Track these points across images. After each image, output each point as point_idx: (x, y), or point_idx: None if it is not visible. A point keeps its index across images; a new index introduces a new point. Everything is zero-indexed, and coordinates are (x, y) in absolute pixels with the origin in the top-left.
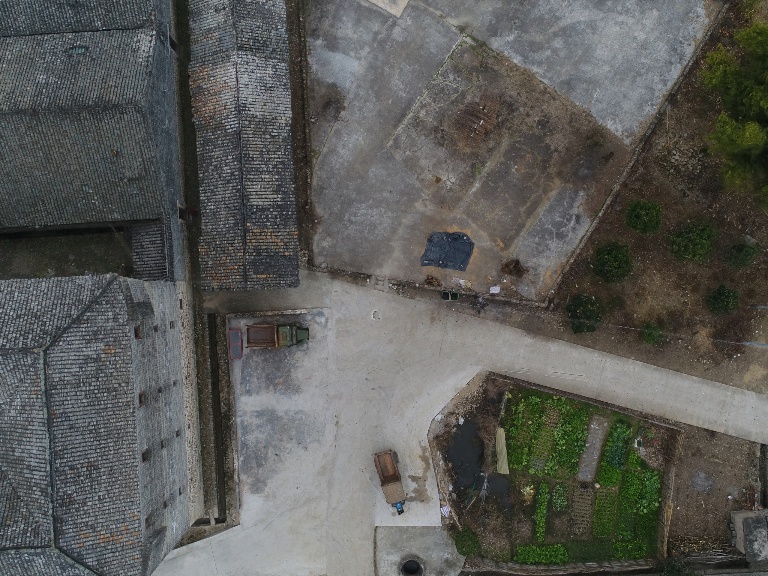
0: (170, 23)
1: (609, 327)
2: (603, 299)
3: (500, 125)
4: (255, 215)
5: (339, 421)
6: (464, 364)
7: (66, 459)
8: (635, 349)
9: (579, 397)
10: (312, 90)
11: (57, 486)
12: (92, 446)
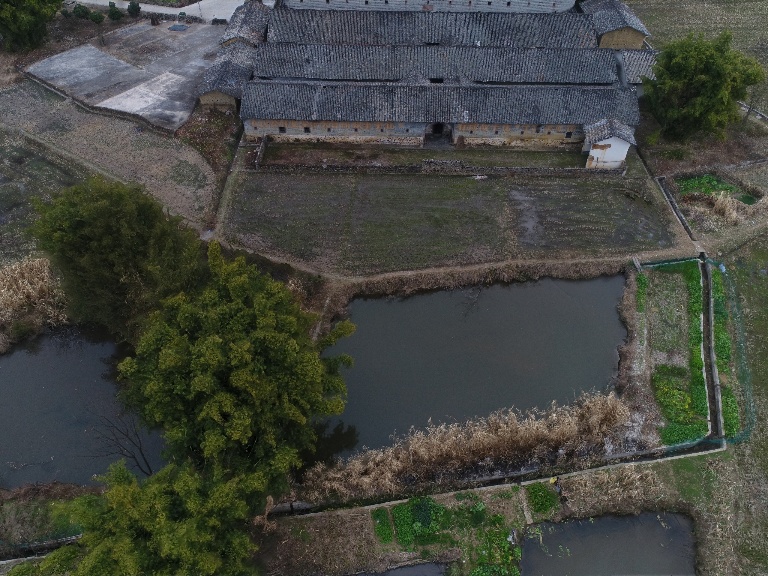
0: None
1: None
2: None
3: None
4: None
5: (238, 0)
6: None
7: None
8: None
9: None
10: None
11: None
12: None
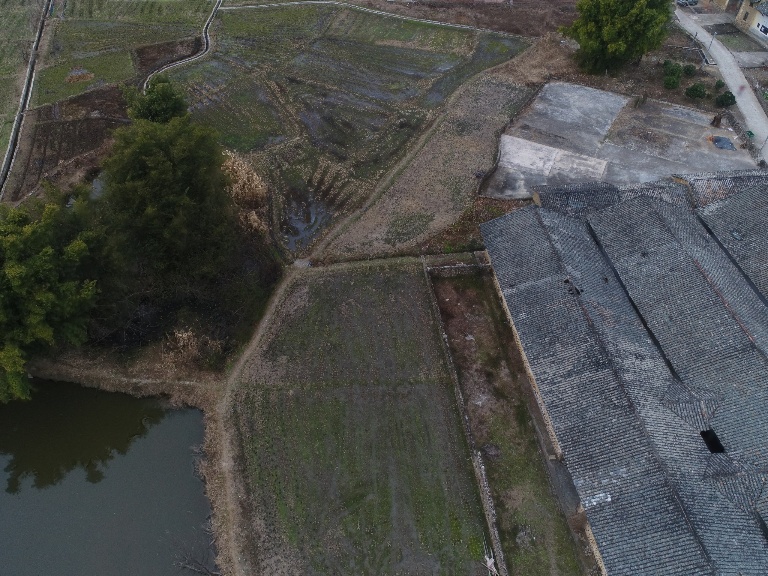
0: None
1: None
2: None
3: None
4: None
5: None
6: None
7: None
8: None
9: (762, 106)
10: None
11: None
12: None
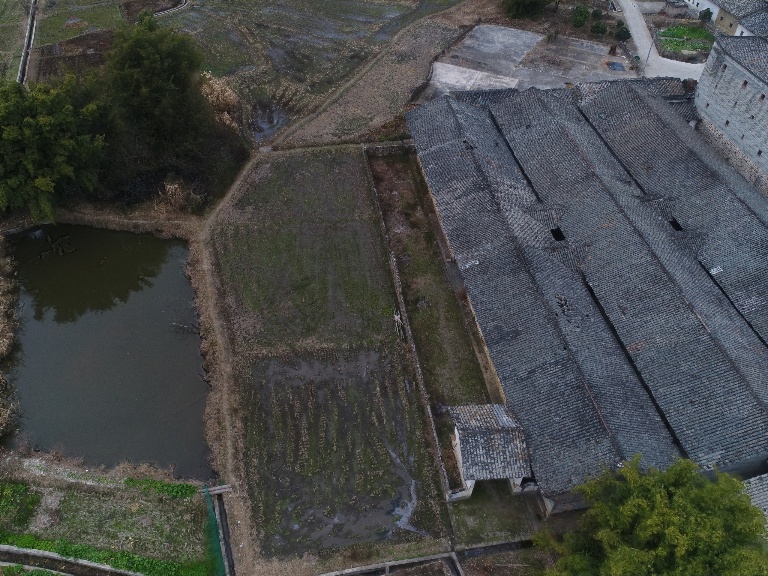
0: None
1: None
2: None
3: None
4: None
5: None
6: (661, 60)
7: None
8: None
9: None
10: None
11: None
12: None
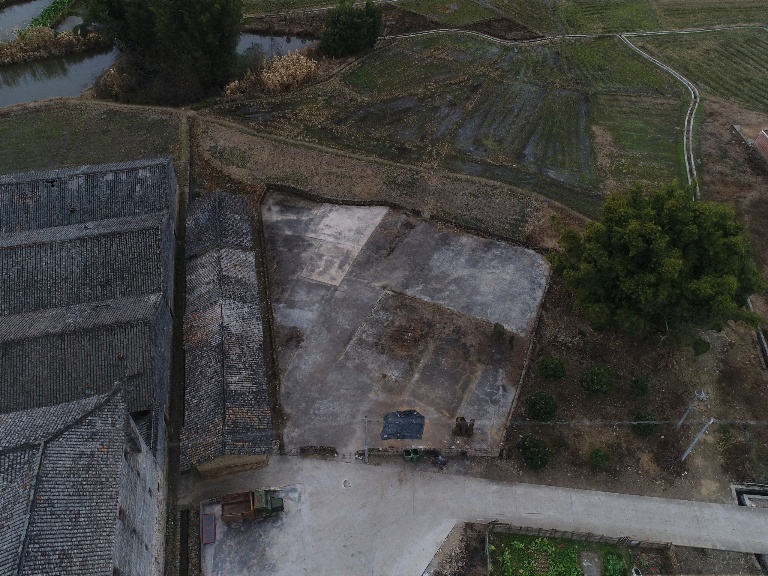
0: (171, 300)
1: (562, 466)
2: (547, 443)
3: (425, 336)
4: (233, 397)
5: None
6: (439, 518)
7: (40, 545)
8: (593, 482)
9: None
10: (278, 332)
11: (23, 572)
12: (69, 534)
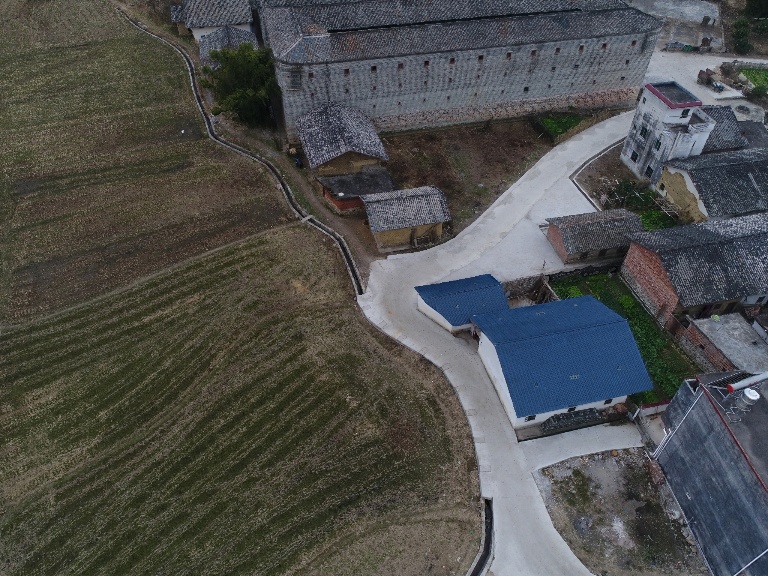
0: None
1: None
2: None
3: None
4: None
5: None
6: None
7: None
8: None
9: None
10: None
11: None
12: None
